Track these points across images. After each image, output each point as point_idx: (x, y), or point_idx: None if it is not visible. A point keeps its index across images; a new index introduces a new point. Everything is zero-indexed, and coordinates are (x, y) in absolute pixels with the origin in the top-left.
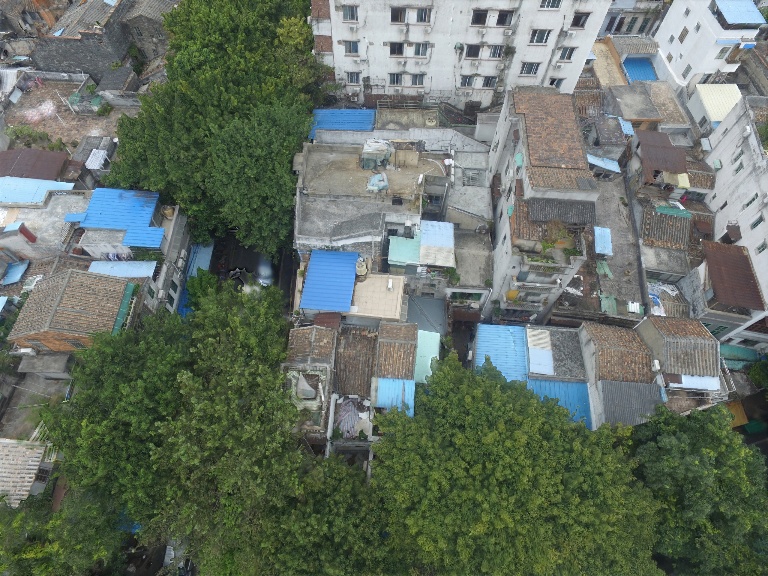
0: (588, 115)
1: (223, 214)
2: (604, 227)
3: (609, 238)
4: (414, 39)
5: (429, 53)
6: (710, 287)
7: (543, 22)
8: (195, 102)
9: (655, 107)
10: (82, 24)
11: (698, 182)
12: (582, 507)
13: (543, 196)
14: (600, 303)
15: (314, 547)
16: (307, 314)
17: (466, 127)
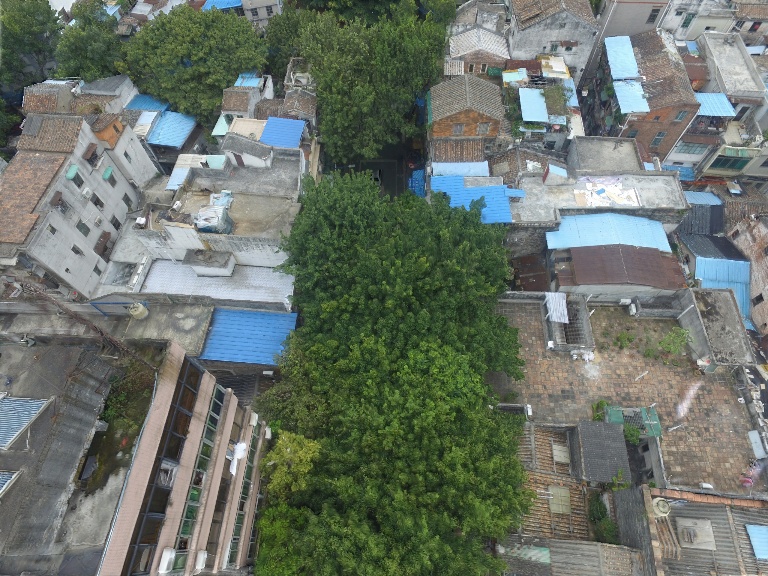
0: None
1: None
2: None
3: None
4: None
5: None
6: None
7: None
8: None
9: None
10: (730, 573)
11: None
12: None
13: None
14: None
15: None
16: None
17: None
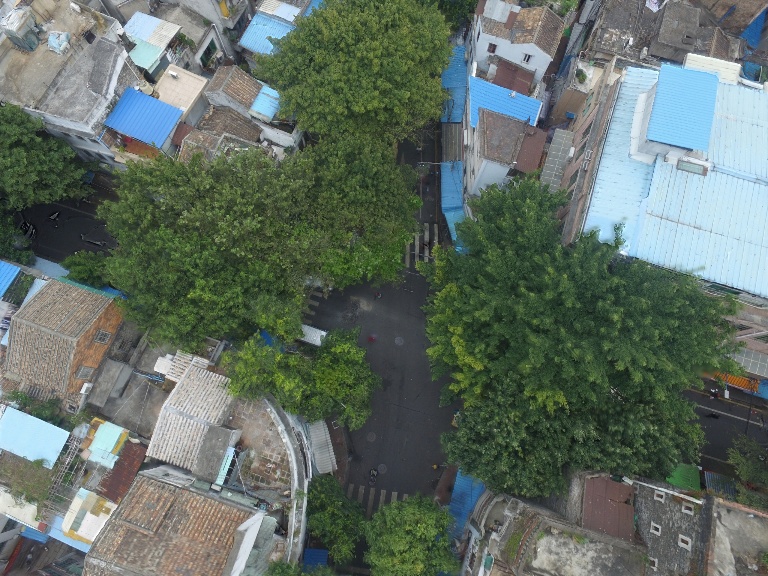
0: None
1: (12, 200)
2: None
3: None
4: None
5: None
6: None
7: None
8: None
9: None
10: None
11: None
12: (387, 7)
13: None
14: None
15: (349, 175)
16: (167, 152)
17: None
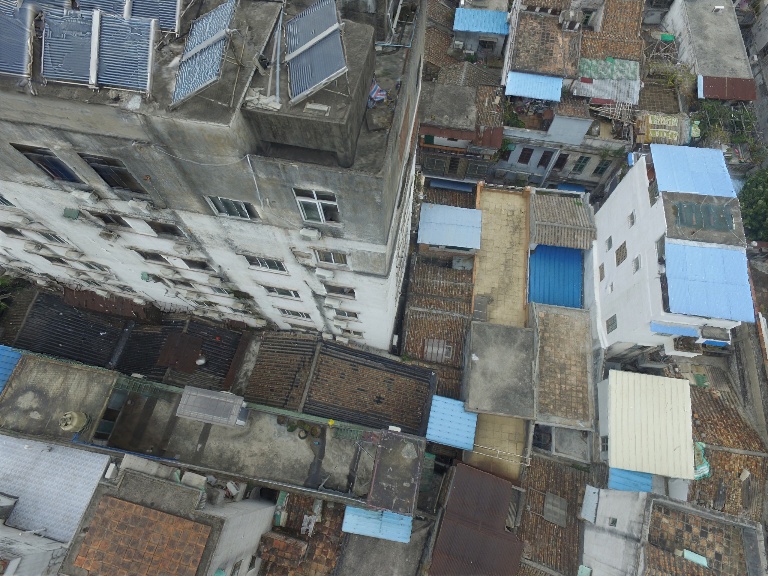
0: (435, 355)
1: None
2: None
3: None
4: None
5: None
6: None
7: (271, 280)
8: None
9: (532, 388)
10: None
11: None
12: None
13: None
14: None
15: None
16: None
17: (181, 392)
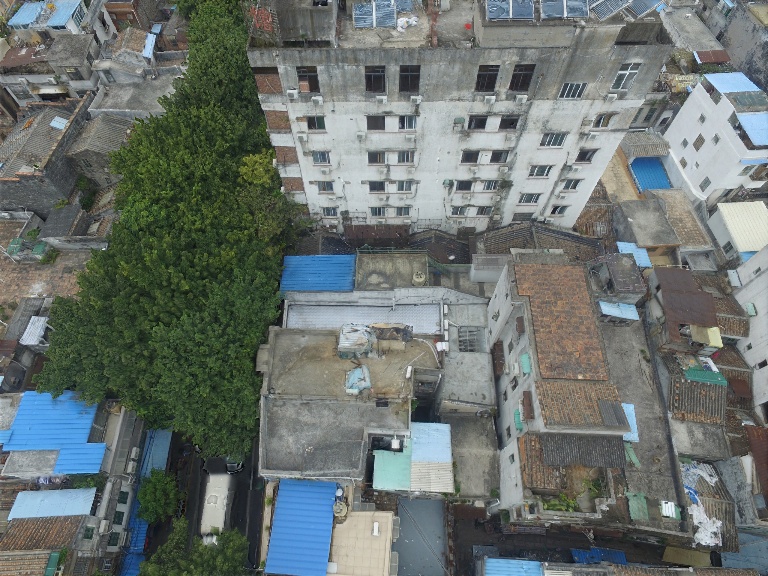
0: (596, 233)
1: None
2: (625, 396)
3: (633, 418)
4: (396, 177)
5: (414, 189)
6: (759, 491)
7: (543, 158)
8: (140, 283)
9: (672, 229)
10: (23, 157)
11: (729, 328)
12: None
13: (559, 431)
14: (628, 506)
15: None
16: None
17: (460, 267)
